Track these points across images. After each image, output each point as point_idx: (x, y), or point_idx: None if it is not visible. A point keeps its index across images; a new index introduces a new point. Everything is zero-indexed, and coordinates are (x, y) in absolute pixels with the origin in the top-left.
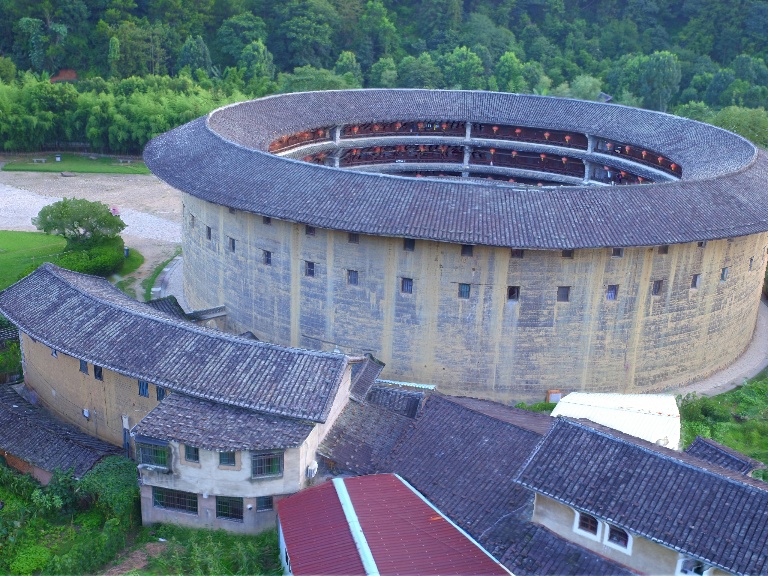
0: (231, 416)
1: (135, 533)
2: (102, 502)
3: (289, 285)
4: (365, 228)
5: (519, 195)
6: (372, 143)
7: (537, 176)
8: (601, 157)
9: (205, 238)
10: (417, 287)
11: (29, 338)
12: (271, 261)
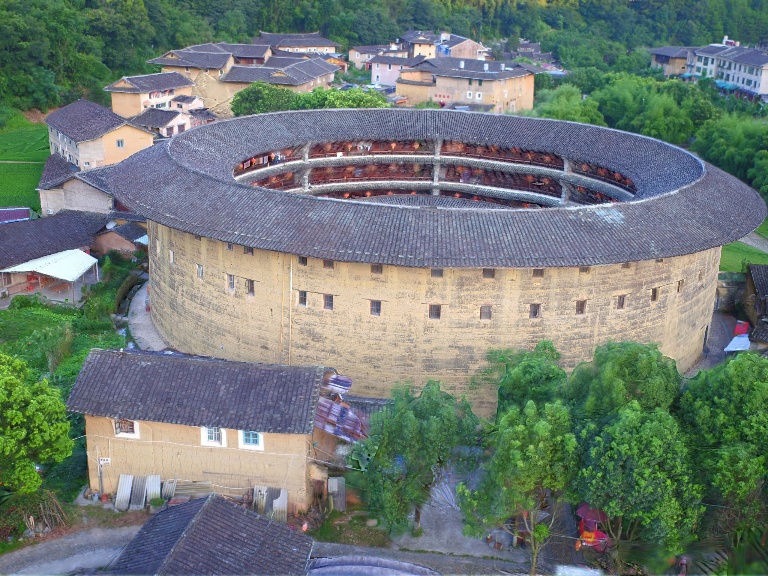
0: None
1: None
2: None
3: None
4: None
5: None
6: (592, 185)
7: None
8: None
9: None
10: None
11: None
12: None
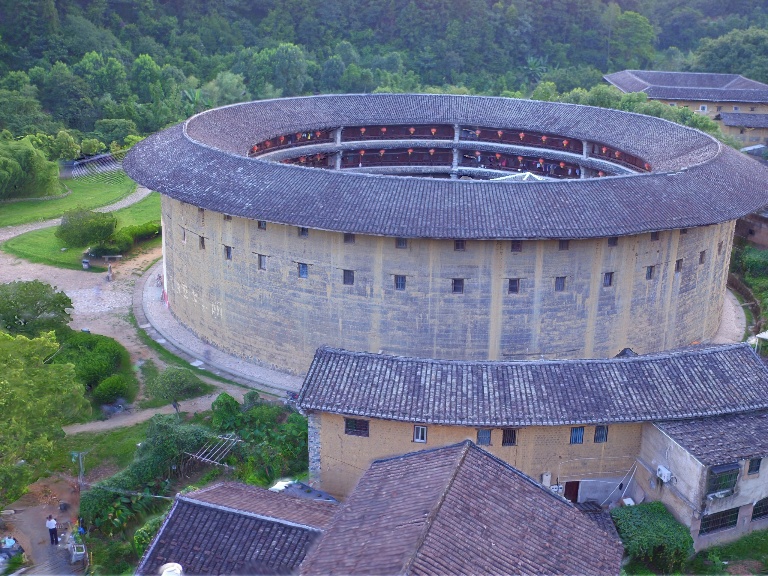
0: (732, 424)
1: (686, 571)
2: (671, 551)
3: (488, 308)
4: (614, 231)
5: (676, 179)
6: None
7: (407, 170)
8: (470, 144)
9: (340, 284)
10: (618, 279)
11: (347, 436)
12: (464, 288)
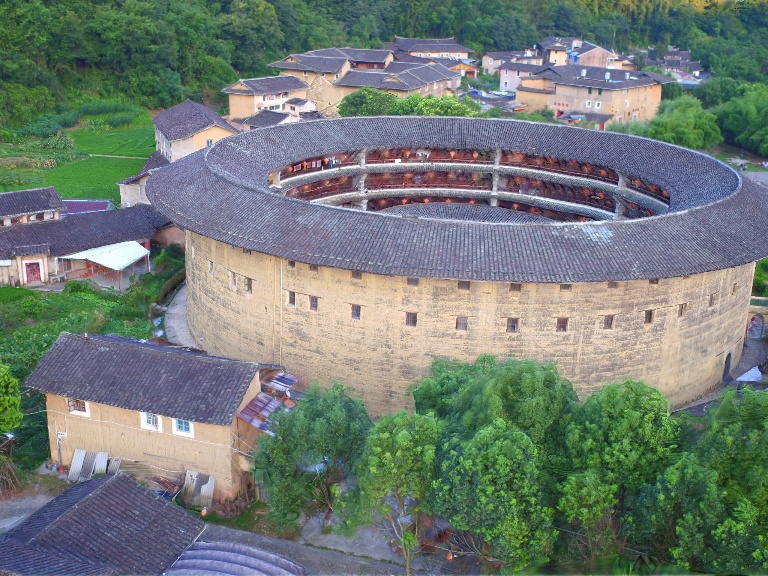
0: None
1: None
2: None
3: None
4: None
5: None
6: (642, 201)
7: None
8: None
9: None
10: None
11: None
12: None
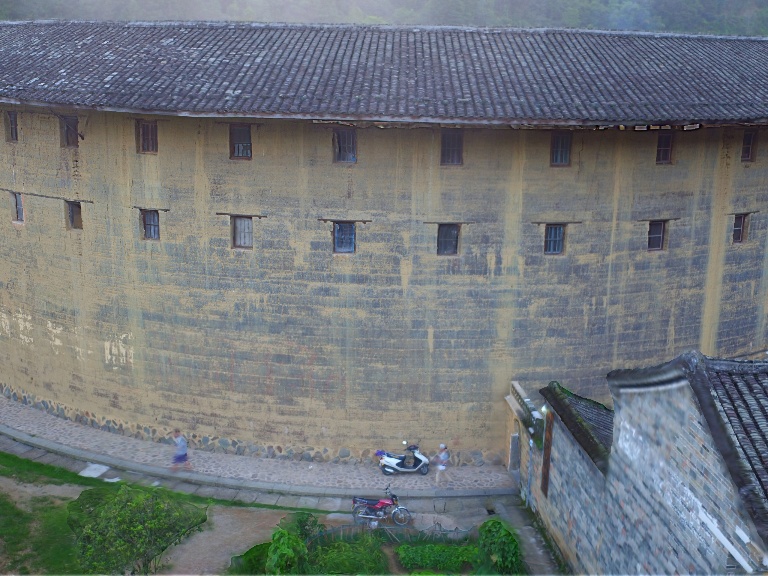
0: None
1: None
2: None
3: (703, 273)
4: None
5: None
6: None
7: None
8: None
9: (432, 255)
10: None
11: None
12: (669, 238)
